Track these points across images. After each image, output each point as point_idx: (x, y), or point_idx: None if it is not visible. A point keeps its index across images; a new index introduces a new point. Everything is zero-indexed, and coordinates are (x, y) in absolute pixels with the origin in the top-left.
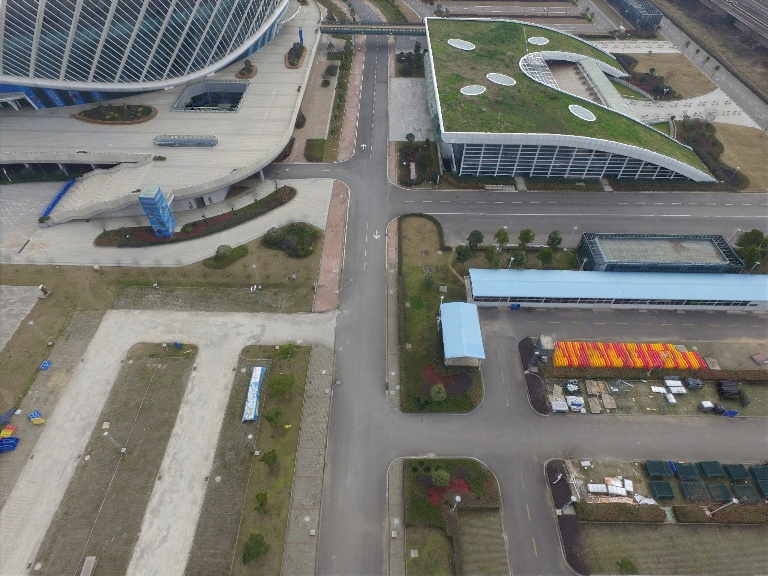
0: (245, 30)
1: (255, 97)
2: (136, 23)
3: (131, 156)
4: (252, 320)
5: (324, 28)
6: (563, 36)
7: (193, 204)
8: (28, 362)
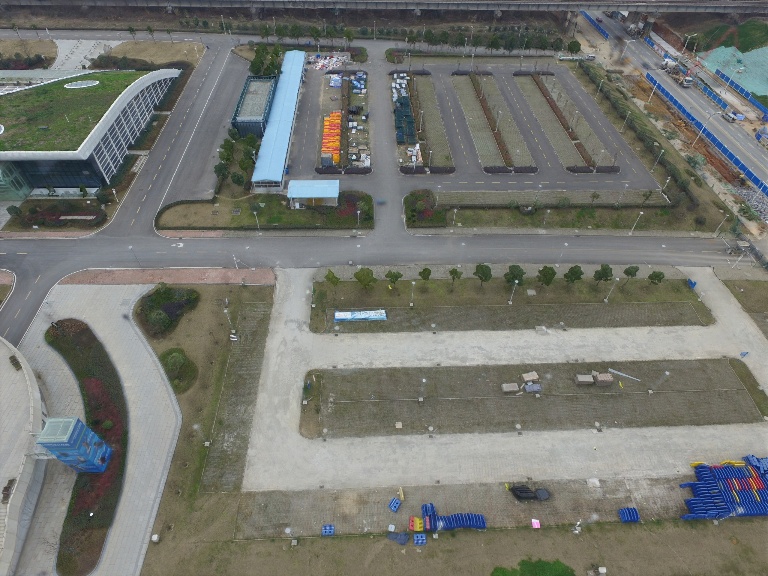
0: None
1: None
2: None
3: None
4: (278, 332)
5: None
6: None
7: None
8: (325, 554)
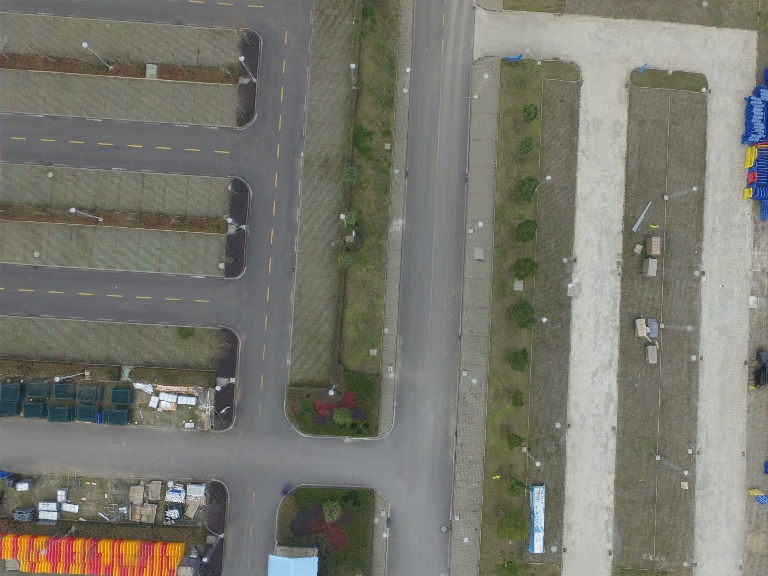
0: None
1: None
2: None
3: None
4: None
5: None
6: None
7: None
8: None
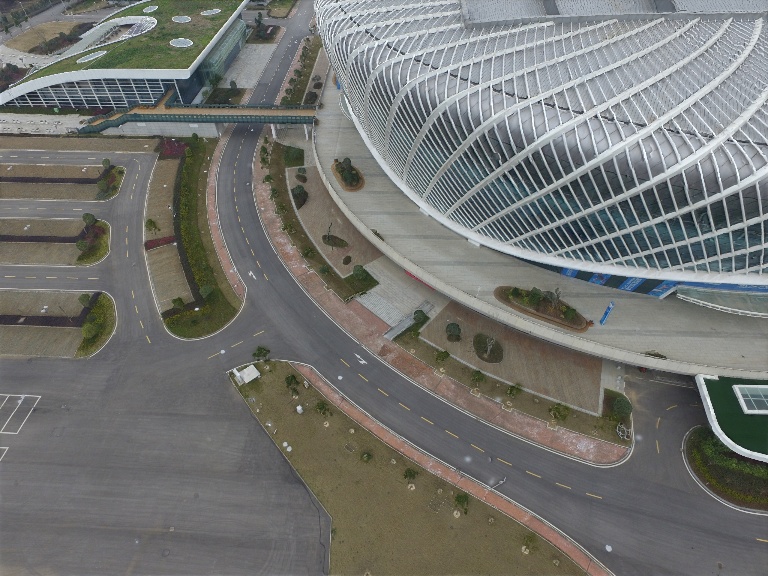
0: None
1: None
2: None
3: None
4: None
5: None
6: None
7: None
8: None
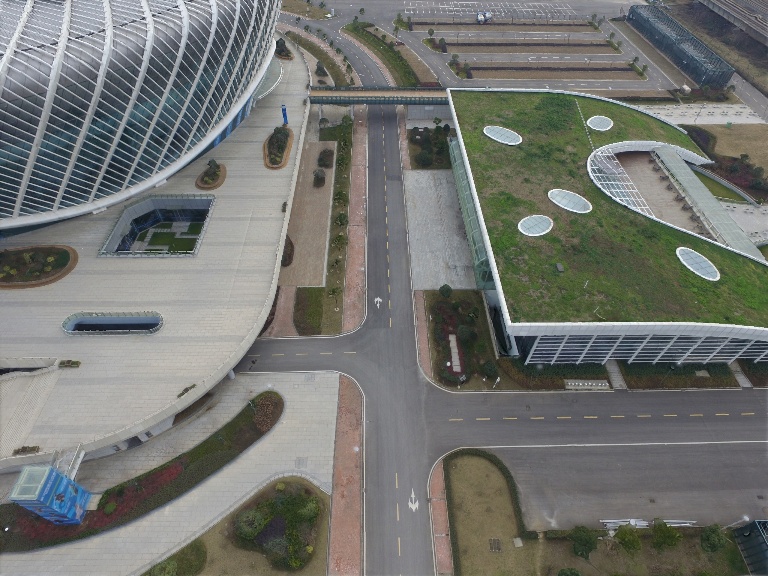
0: (207, 120)
1: (222, 225)
2: (33, 146)
3: (24, 361)
4: None
5: (314, 97)
6: (625, 110)
7: (121, 445)
8: None
